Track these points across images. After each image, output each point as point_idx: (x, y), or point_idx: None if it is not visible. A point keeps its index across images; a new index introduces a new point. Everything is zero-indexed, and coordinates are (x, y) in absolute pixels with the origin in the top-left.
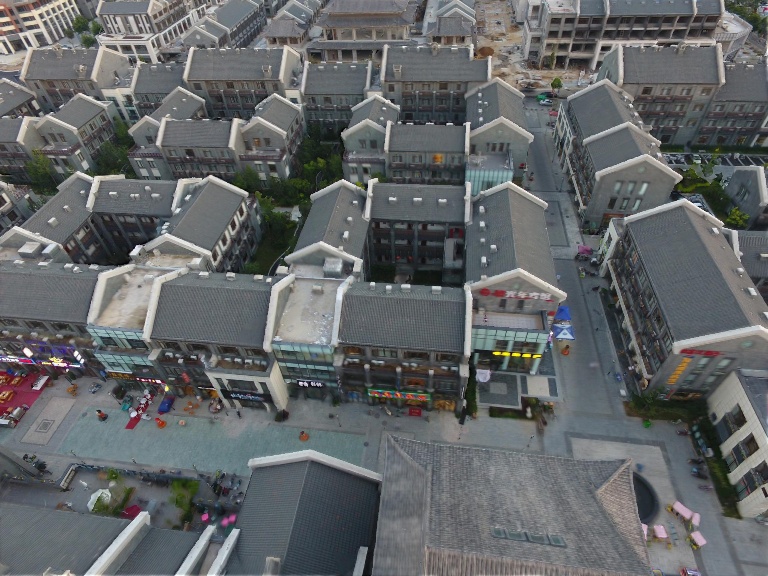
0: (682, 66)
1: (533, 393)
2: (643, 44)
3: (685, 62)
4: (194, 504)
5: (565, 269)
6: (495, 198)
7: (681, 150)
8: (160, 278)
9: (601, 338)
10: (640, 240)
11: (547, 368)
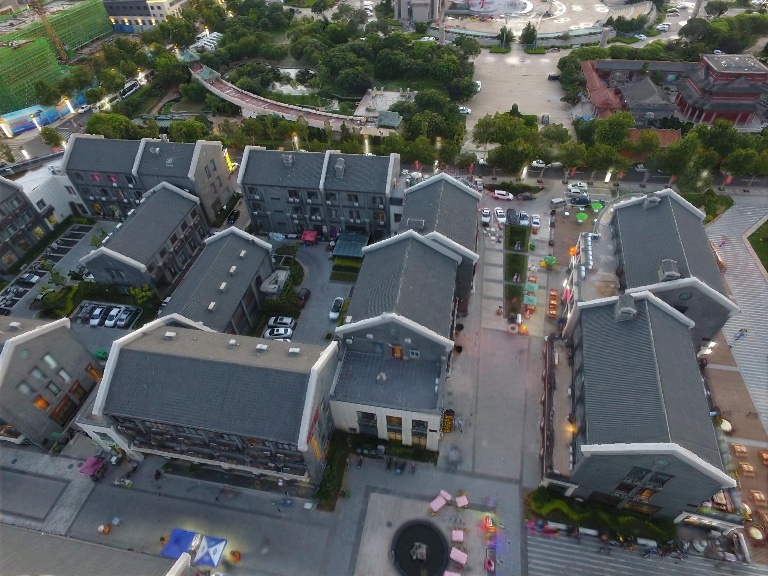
0: None
1: None
2: None
3: None
4: None
5: (105, 504)
6: None
7: (4, 283)
8: None
9: (230, 499)
10: (139, 412)
11: None
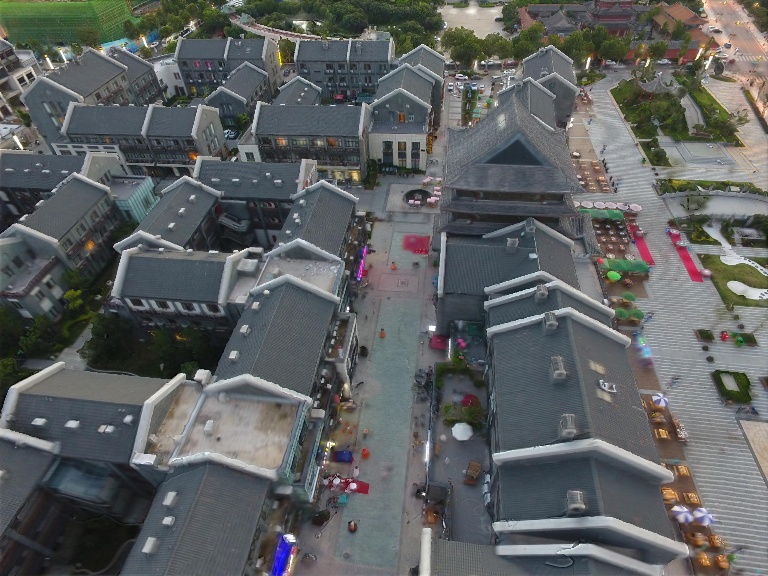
0: (93, 71)
1: None
2: None
3: (91, 68)
4: (454, 365)
5: None
6: (207, 171)
7: None
8: (244, 375)
9: None
10: (275, 131)
11: None
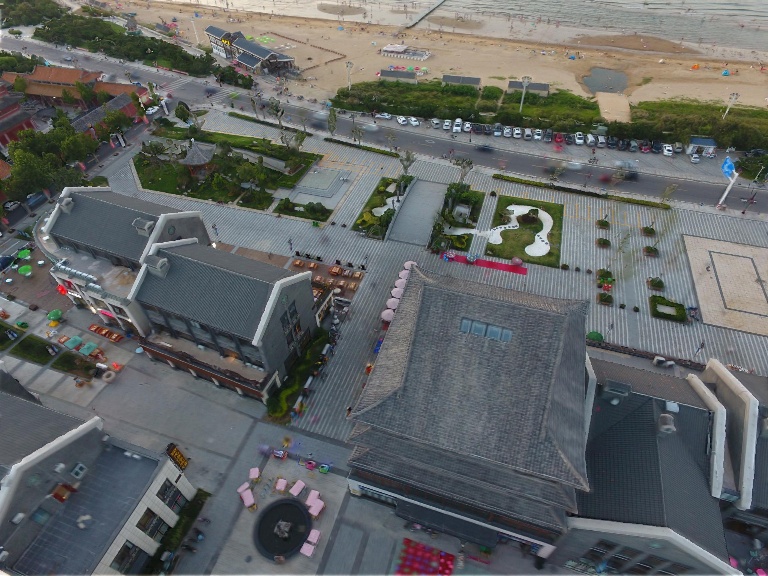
0: None
1: None
2: None
3: None
4: None
5: None
6: None
7: None
8: None
9: None
10: None
11: None
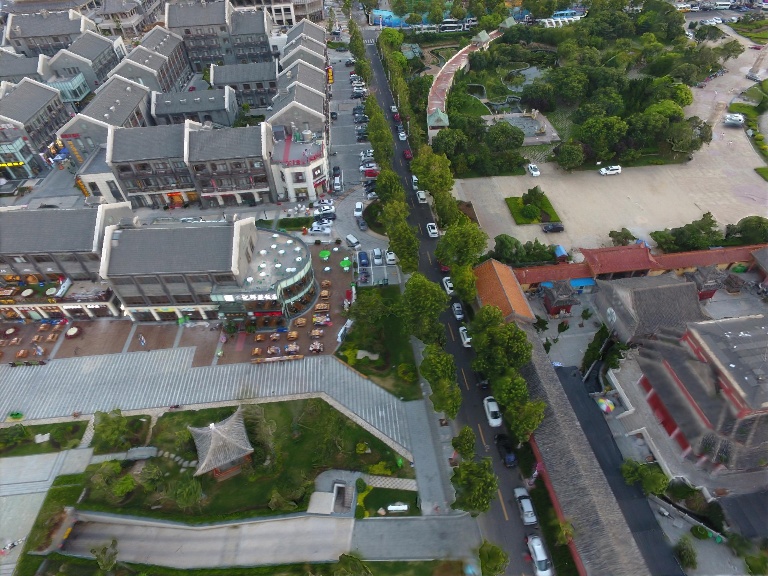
0: (205, 14)
1: (25, 185)
2: (245, 10)
3: (207, 12)
4: None
5: None
6: None
7: None
8: None
9: None
10: None
11: (43, 175)
